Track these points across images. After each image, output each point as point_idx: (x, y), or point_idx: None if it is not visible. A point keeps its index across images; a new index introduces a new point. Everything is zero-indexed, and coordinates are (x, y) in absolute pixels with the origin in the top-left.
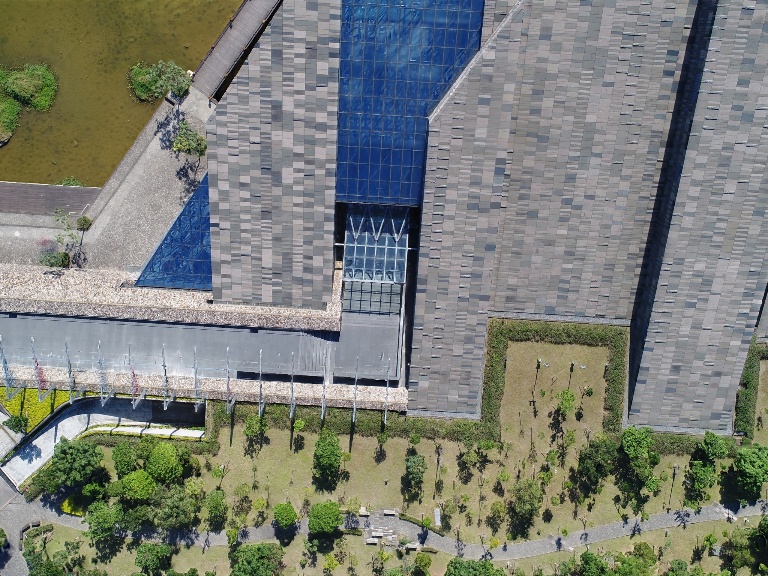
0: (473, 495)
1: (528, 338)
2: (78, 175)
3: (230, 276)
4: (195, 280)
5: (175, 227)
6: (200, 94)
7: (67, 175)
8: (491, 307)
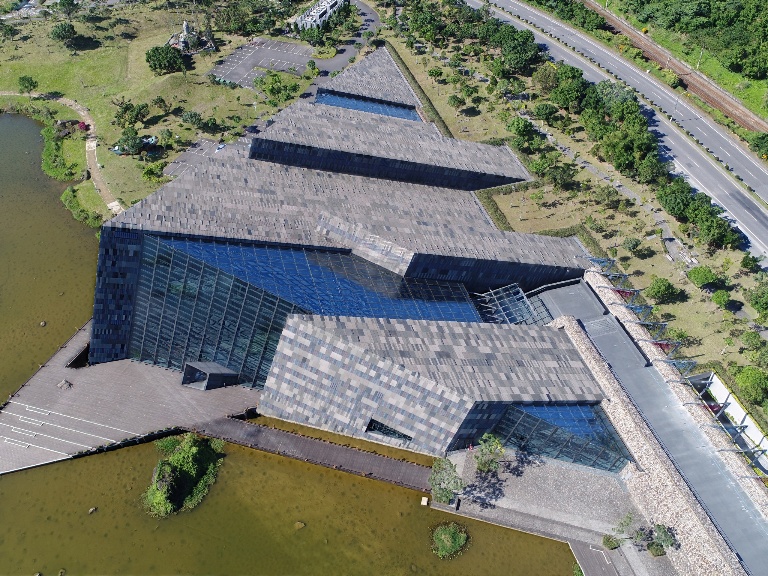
0: None
1: (511, 227)
2: (569, 574)
3: (581, 388)
4: None
5: (568, 437)
6: None
7: None
8: None
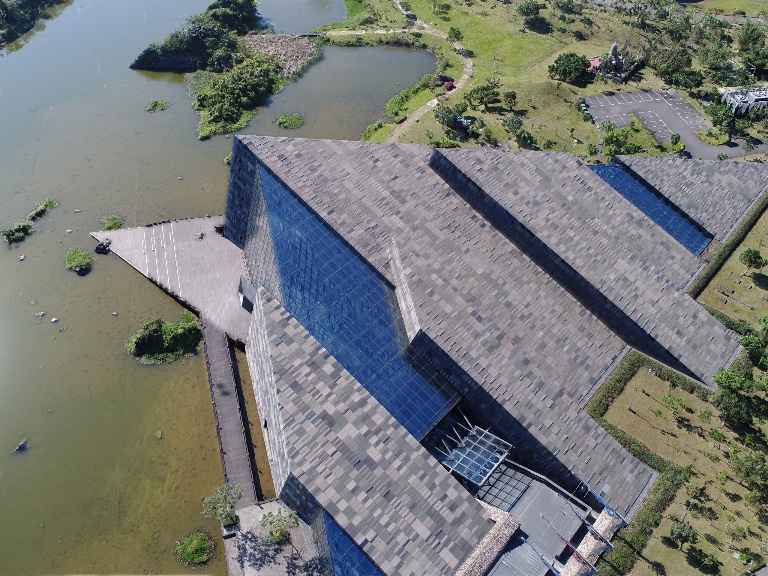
0: None
1: (607, 405)
2: None
3: (413, 574)
4: None
5: None
6: (247, 509)
7: None
8: None
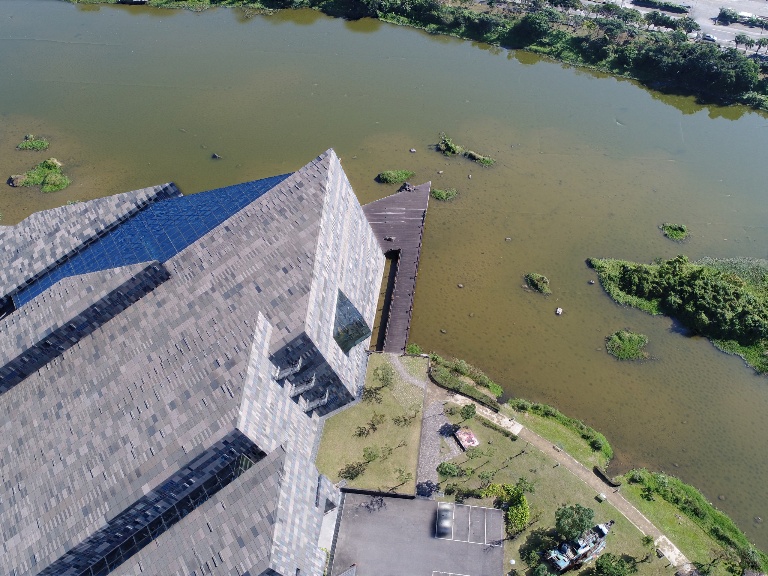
0: None
1: None
2: (5, 217)
3: None
4: None
5: None
6: None
7: (3, 213)
8: None
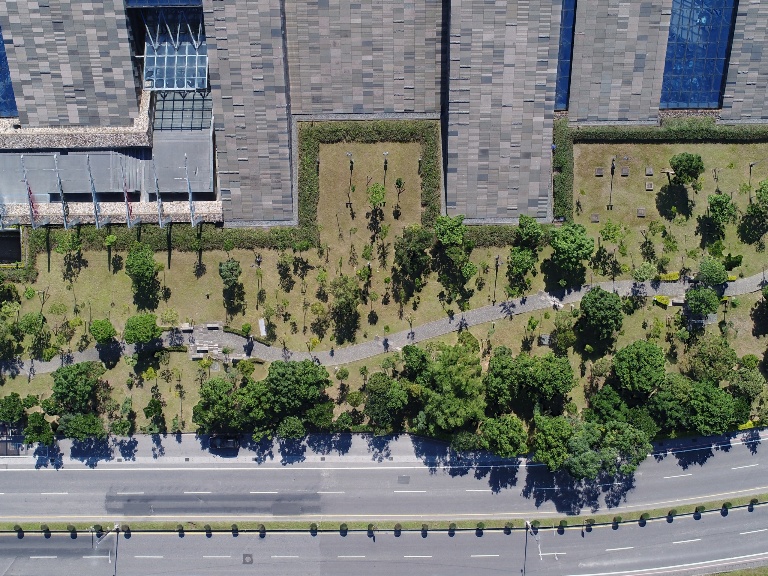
0: (297, 303)
1: (338, 139)
2: None
3: (33, 97)
4: (4, 110)
5: None
6: None
7: None
8: (299, 110)
